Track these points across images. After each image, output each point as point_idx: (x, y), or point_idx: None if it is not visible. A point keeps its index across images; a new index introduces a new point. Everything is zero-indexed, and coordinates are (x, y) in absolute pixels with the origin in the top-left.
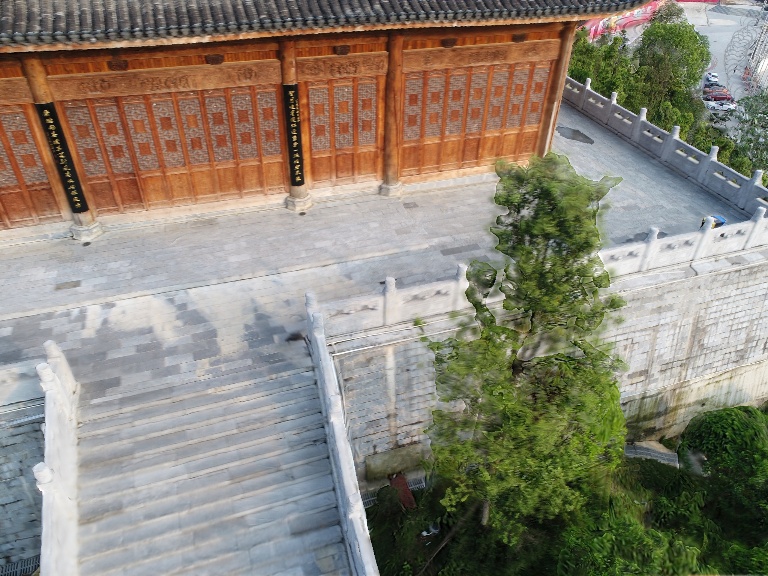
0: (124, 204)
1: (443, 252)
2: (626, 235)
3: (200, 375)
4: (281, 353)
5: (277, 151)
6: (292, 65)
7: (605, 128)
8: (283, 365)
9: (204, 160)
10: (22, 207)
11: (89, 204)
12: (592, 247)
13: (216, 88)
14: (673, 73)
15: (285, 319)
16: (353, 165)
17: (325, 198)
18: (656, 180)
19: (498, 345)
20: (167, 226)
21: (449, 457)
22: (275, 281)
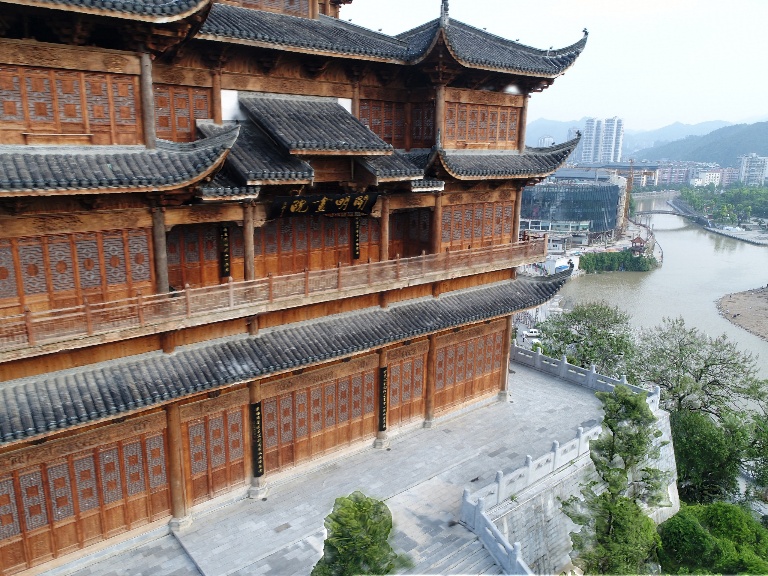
0: (282, 465)
1: (490, 456)
2: (576, 425)
3: (419, 559)
4: (453, 534)
5: (372, 410)
6: (386, 355)
7: (514, 362)
8: (461, 540)
9: (332, 424)
10: (222, 480)
11: (264, 469)
12: (656, 420)
13: (346, 376)
14: None
15: (437, 515)
16: (410, 411)
17: (395, 436)
18: (566, 390)
19: (618, 477)
20: (308, 476)
21: (596, 555)
22: (409, 495)
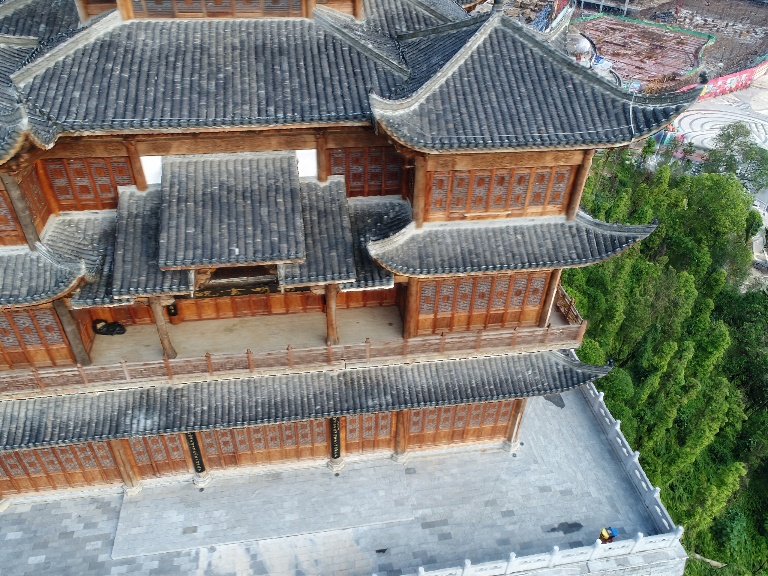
0: (226, 465)
1: (423, 525)
2: (553, 524)
3: None
4: None
5: (324, 440)
6: None
7: None
8: None
9: (277, 446)
10: (167, 468)
11: (206, 467)
12: None
13: None
14: (716, 220)
15: None
16: (374, 445)
17: (354, 461)
18: (596, 461)
19: None
20: (251, 477)
21: None
22: (311, 540)
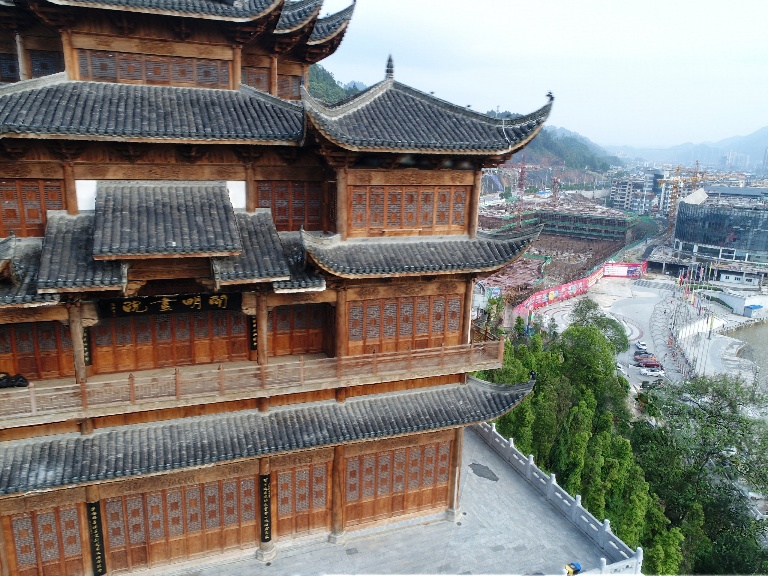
0: (133, 565)
1: None
2: None
3: None
4: None
5: (252, 517)
6: (267, 462)
7: (508, 464)
8: None
9: (198, 528)
10: (57, 574)
11: (107, 568)
12: None
13: (213, 481)
14: (591, 365)
15: None
16: (309, 522)
17: (287, 548)
18: (542, 519)
19: None
20: None
21: None
22: None
